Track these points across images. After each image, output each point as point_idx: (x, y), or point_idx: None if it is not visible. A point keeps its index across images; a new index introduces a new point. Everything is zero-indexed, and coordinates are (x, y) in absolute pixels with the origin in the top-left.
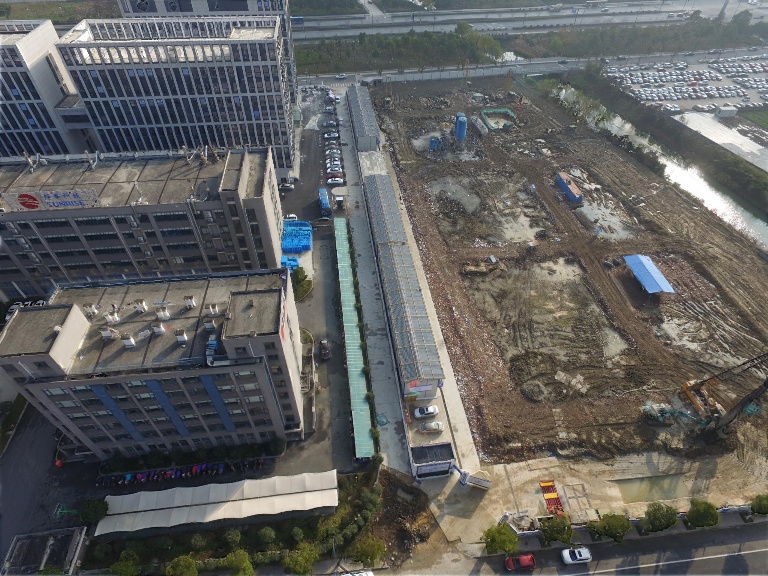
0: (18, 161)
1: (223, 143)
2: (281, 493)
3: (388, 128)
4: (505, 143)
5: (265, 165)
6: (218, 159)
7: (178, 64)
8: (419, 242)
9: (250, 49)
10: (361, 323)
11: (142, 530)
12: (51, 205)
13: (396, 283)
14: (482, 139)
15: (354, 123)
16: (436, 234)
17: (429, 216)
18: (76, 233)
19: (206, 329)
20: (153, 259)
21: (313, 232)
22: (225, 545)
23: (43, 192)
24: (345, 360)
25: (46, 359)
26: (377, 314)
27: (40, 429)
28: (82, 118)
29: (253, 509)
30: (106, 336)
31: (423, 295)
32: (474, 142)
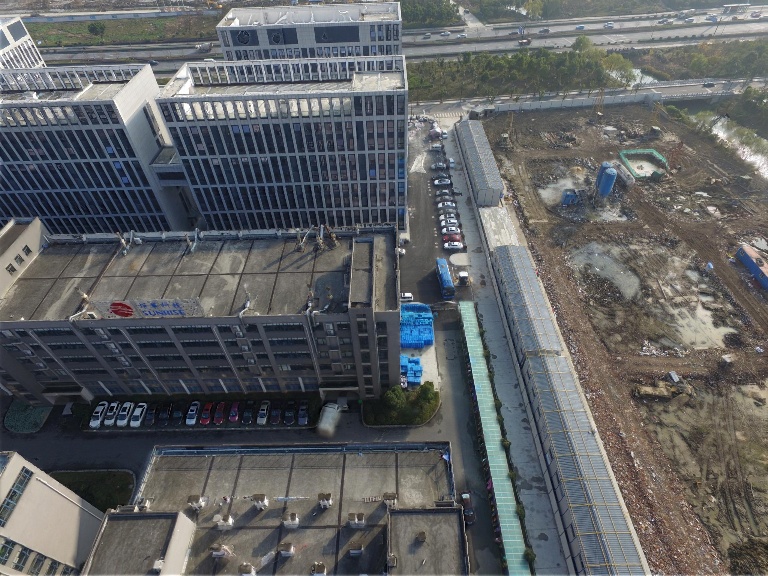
0: (110, 238)
1: (330, 203)
2: None
3: (508, 173)
4: (657, 197)
5: (393, 254)
6: (336, 243)
7: (289, 119)
8: (569, 341)
9: (375, 102)
10: (513, 473)
11: None
12: (147, 313)
13: (559, 420)
14: (627, 191)
15: (472, 170)
16: (590, 331)
17: (576, 302)
18: (172, 340)
19: (350, 553)
20: (256, 366)
21: (433, 318)
22: None
23: (139, 301)
24: (496, 529)
25: None
26: (528, 453)
27: None
28: (178, 175)
29: None
30: (217, 554)
31: (597, 440)
32: (617, 195)
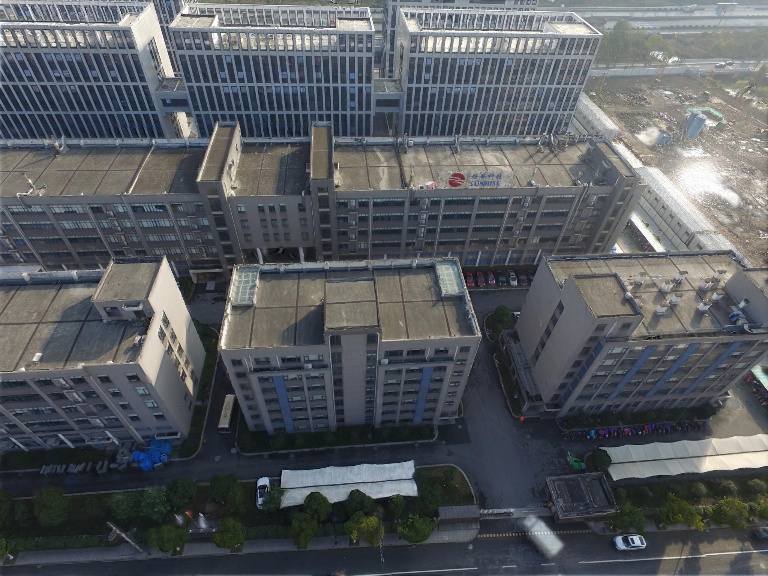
0: (384, 142)
1: (508, 131)
2: (748, 451)
3: None
4: (726, 141)
5: None
6: None
7: (507, 55)
8: None
9: (576, 43)
10: None
11: (636, 478)
12: (472, 184)
13: None
14: (703, 136)
15: (586, 116)
16: (719, 225)
17: (701, 208)
18: (472, 211)
19: (712, 301)
20: (515, 238)
21: None
22: (719, 493)
23: (474, 172)
24: None
25: (636, 320)
26: None
27: (480, 388)
28: (393, 102)
29: (735, 463)
30: None
31: None
32: (696, 139)
